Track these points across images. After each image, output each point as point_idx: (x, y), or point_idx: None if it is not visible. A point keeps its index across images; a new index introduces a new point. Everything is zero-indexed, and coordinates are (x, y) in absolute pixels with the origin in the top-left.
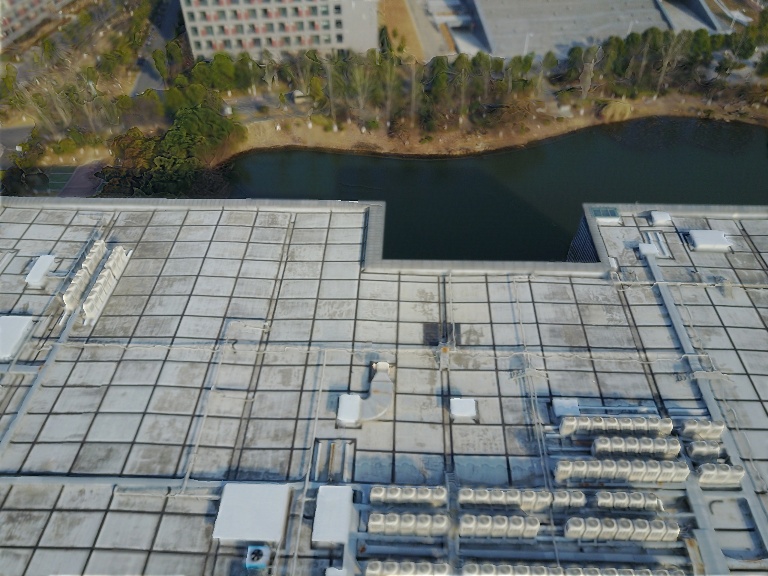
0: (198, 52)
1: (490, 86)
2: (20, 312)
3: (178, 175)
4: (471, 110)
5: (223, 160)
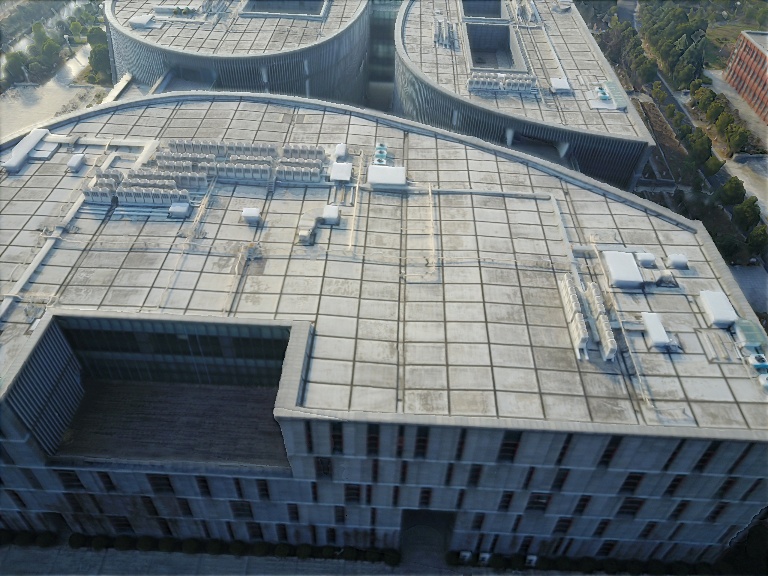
0: None
1: None
2: (636, 295)
3: None
4: None
5: None
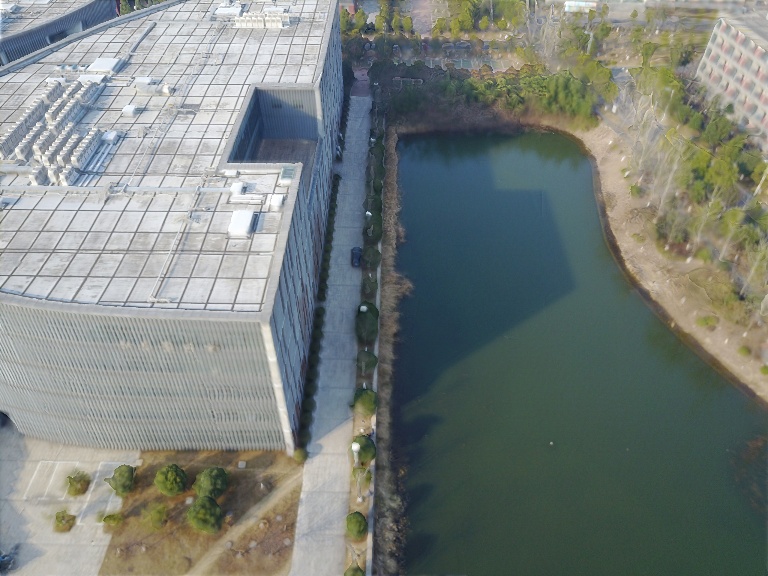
0: (700, 73)
1: (731, 250)
2: None
3: (484, 91)
4: (719, 268)
5: (555, 127)
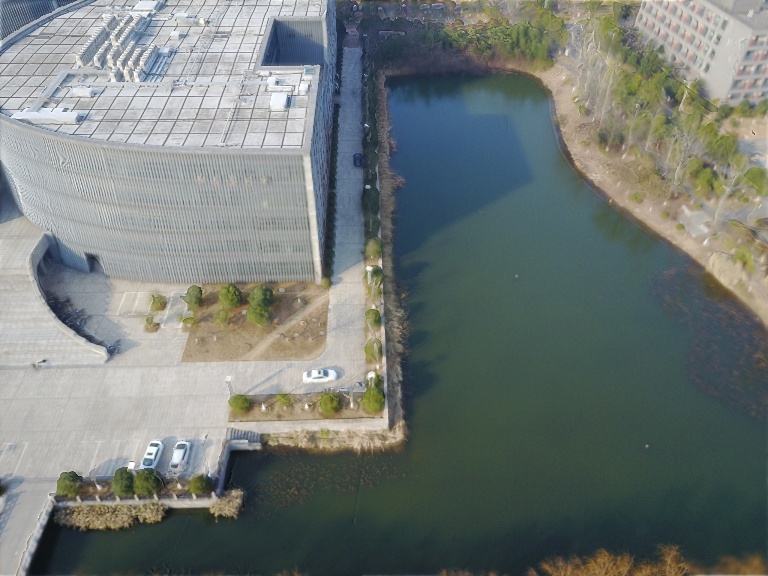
0: (638, 23)
1: (653, 140)
2: None
3: (458, 38)
4: None
5: (518, 69)
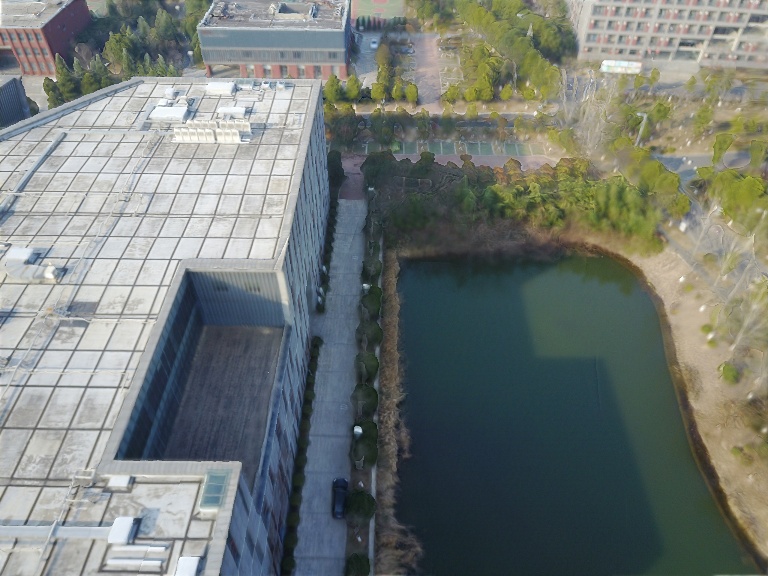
0: None
1: None
2: (196, 115)
3: (513, 203)
4: None
5: (604, 247)
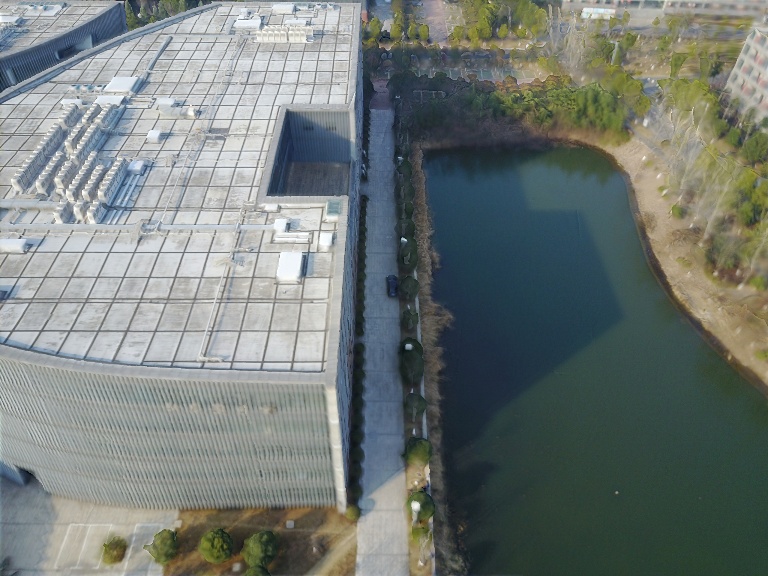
0: (731, 84)
1: None
2: None
3: (511, 104)
4: None
5: (584, 141)
